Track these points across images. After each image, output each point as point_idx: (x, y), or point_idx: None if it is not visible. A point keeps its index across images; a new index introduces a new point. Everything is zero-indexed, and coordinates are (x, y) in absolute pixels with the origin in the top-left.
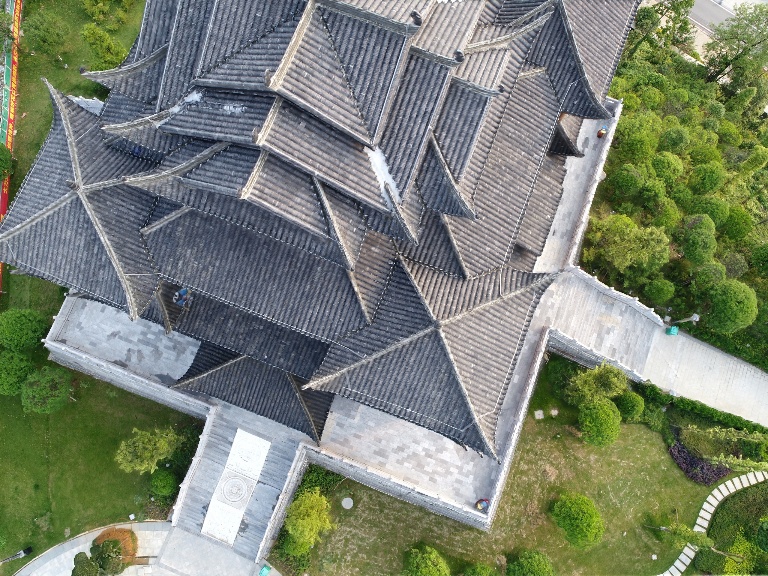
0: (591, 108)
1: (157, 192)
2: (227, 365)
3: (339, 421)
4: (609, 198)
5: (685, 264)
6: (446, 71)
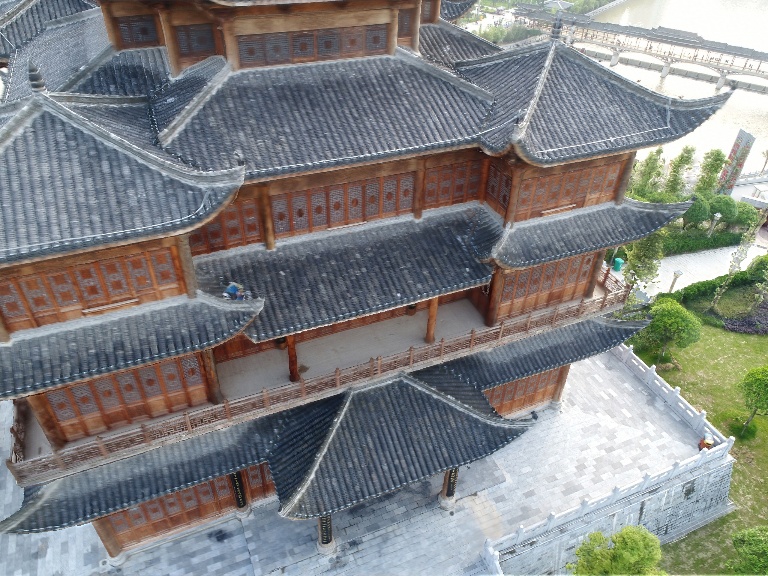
0: (460, 7)
1: None
2: (333, 437)
3: (494, 496)
4: None
5: None
6: None
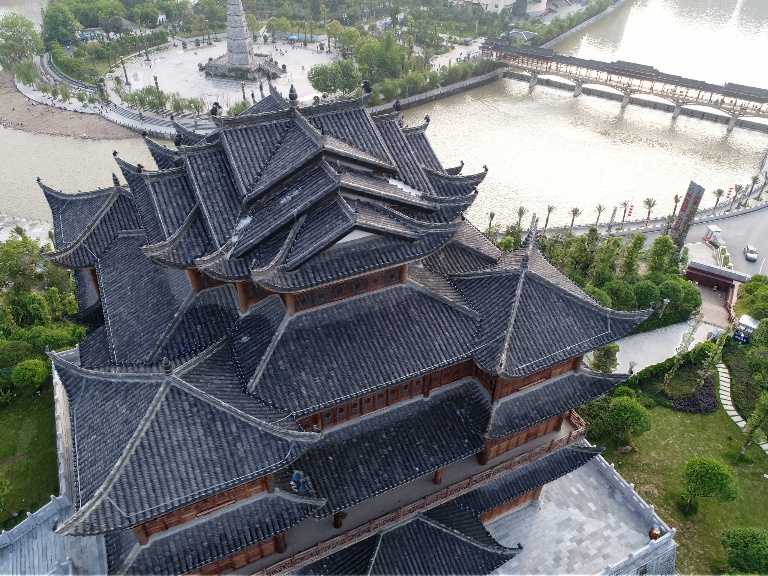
0: None
1: (273, 285)
2: (370, 572)
3: None
4: None
5: None
6: (393, 124)
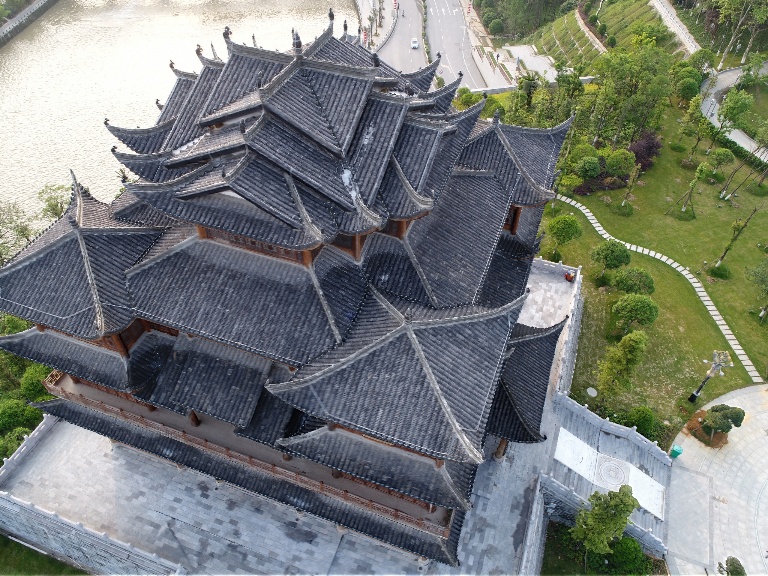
0: None
1: None
2: None
3: None
4: None
5: None
6: None
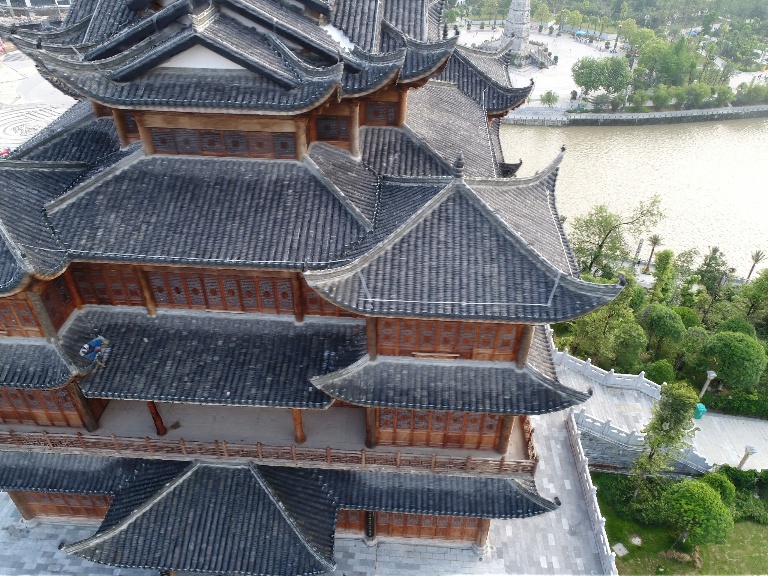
0: (510, 98)
1: (79, 85)
2: (161, 499)
3: None
4: (557, 334)
5: (664, 350)
6: None
